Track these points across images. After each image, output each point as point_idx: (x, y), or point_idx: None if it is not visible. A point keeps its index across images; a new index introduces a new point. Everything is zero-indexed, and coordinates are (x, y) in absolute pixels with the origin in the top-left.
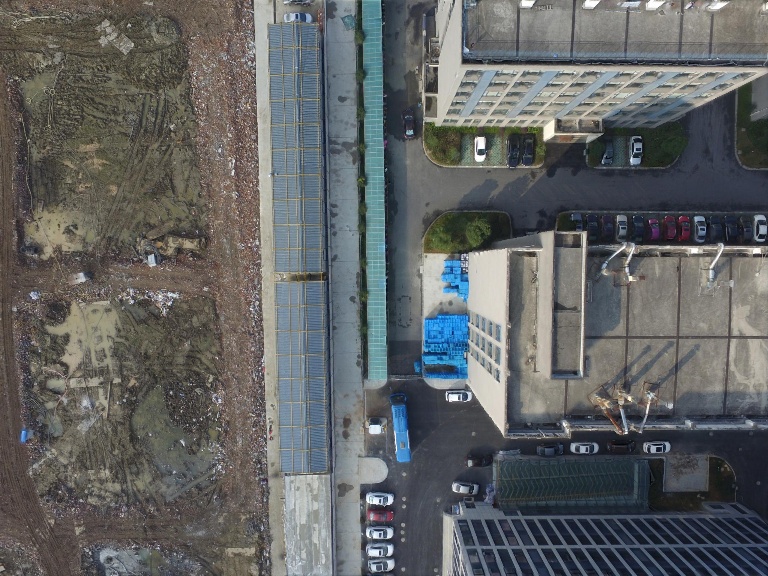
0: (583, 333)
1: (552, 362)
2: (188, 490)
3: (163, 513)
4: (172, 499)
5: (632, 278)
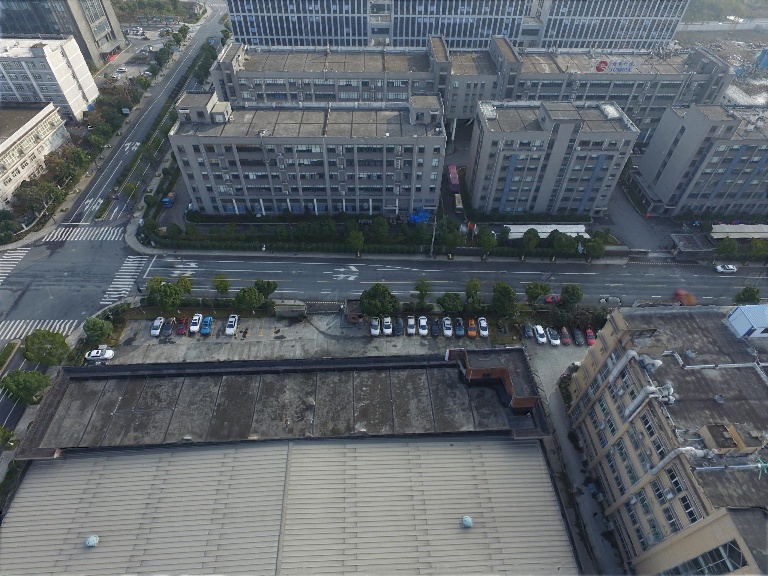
0: None
1: None
2: (759, 94)
3: (764, 90)
4: (764, 93)
5: None
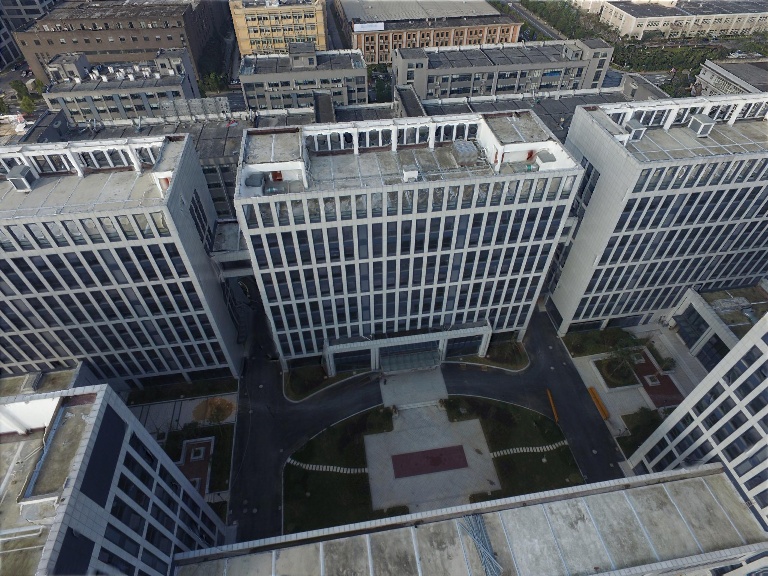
0: (45, 130)
1: (25, 140)
2: None
3: None
4: None
5: (87, 123)
